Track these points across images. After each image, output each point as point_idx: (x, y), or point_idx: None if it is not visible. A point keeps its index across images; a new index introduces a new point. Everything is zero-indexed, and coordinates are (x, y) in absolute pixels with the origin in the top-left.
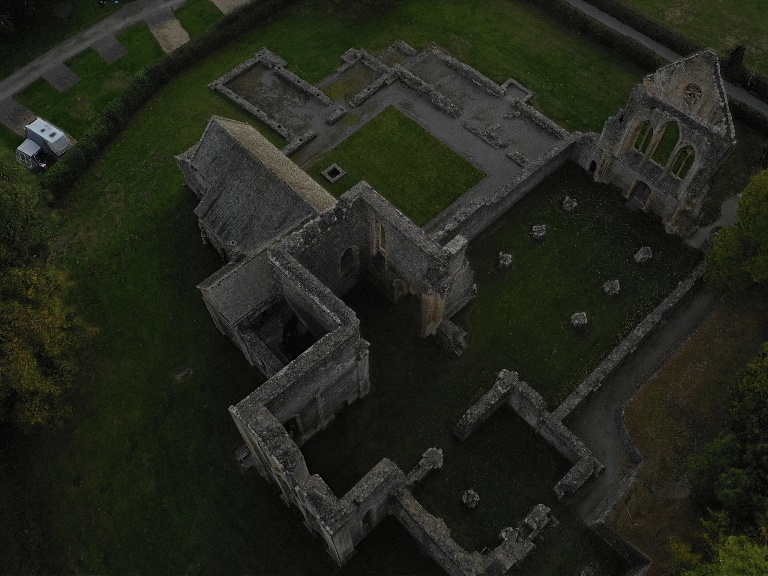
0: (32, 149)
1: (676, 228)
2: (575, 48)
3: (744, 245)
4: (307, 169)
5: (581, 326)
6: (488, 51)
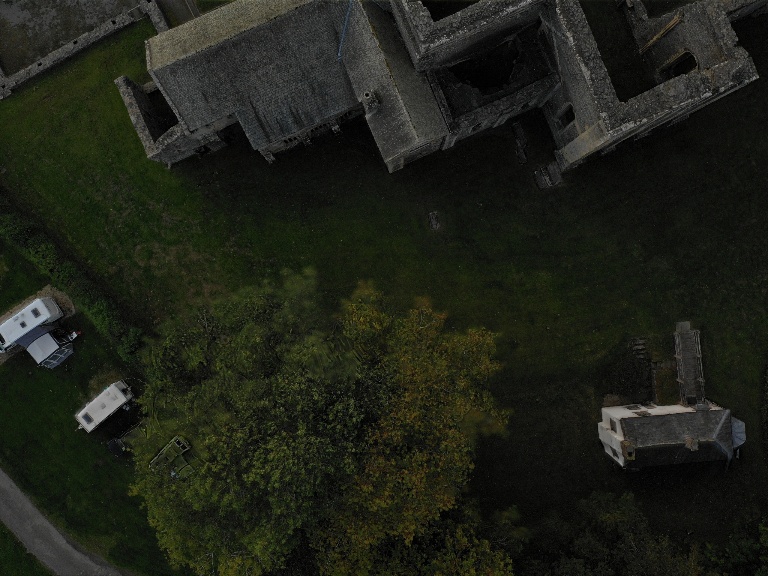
0: (48, 344)
1: None
2: None
3: None
4: (199, 9)
5: None
6: None
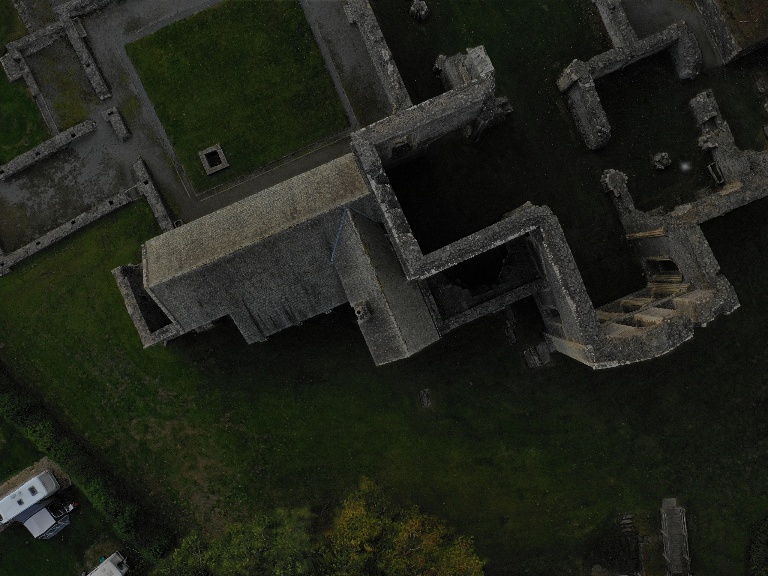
0: (45, 519)
1: None
2: None
3: None
4: (194, 189)
5: None
6: None
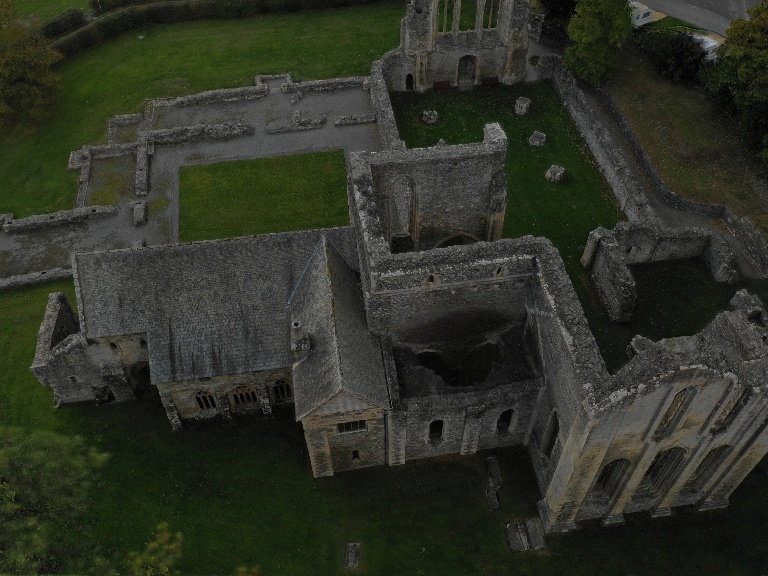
0: None
1: (514, 75)
2: (274, 27)
3: (599, 23)
4: None
5: (562, 176)
6: (207, 72)
